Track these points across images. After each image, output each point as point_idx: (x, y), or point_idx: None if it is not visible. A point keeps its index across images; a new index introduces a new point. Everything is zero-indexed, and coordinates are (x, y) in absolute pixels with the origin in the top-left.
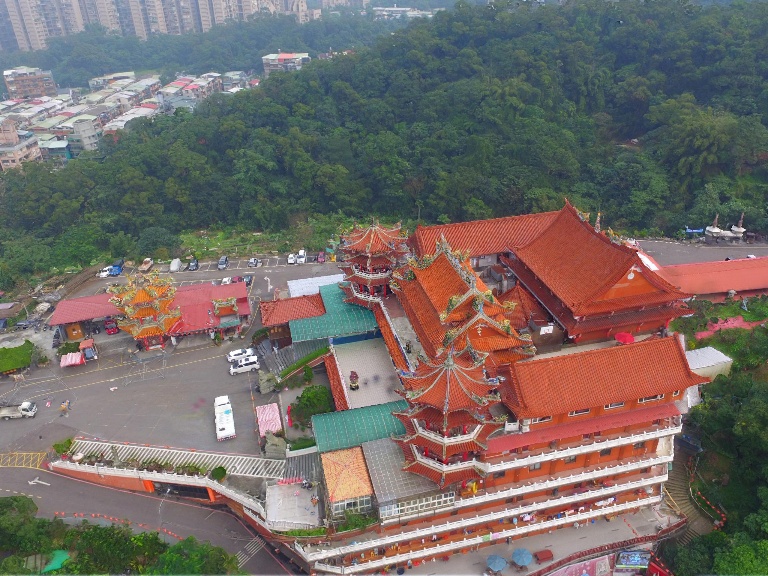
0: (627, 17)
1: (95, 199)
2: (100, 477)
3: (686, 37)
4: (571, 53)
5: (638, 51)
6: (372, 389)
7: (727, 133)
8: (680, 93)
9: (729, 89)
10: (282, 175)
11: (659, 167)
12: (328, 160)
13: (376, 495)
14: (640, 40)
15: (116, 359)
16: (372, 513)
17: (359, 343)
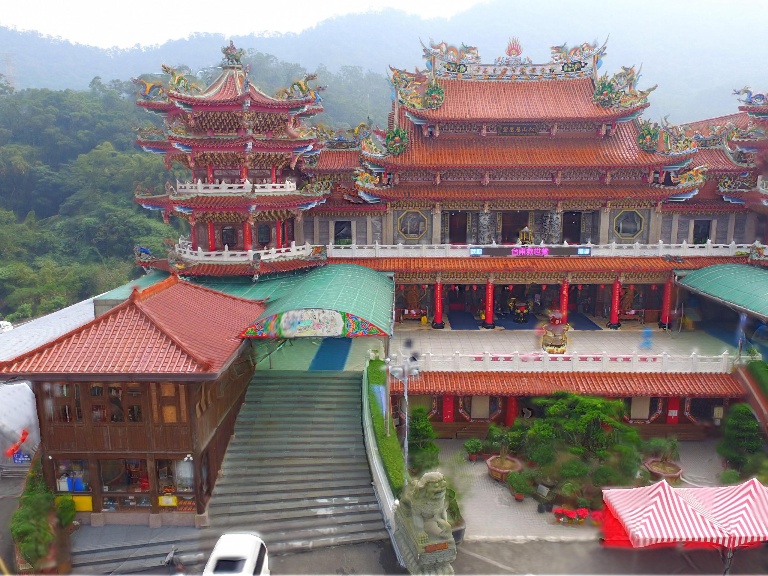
0: None
1: None
2: None
3: (40, 103)
4: None
5: None
6: None
7: None
8: (56, 167)
9: (124, 150)
10: None
11: (136, 214)
12: None
13: None
14: None
15: None
16: None
17: (360, 347)
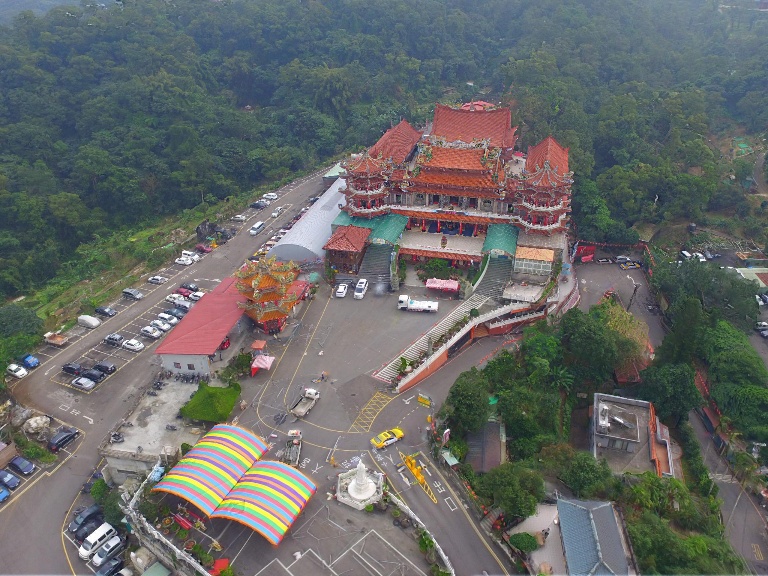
0: (191, 12)
1: None
2: None
3: (253, 22)
4: (184, 45)
5: (213, 38)
6: (451, 244)
7: (346, 76)
8: (263, 64)
9: (303, 53)
10: None
11: (315, 111)
12: (38, 194)
13: (559, 248)
14: (212, 29)
15: (274, 349)
16: (558, 261)
17: None
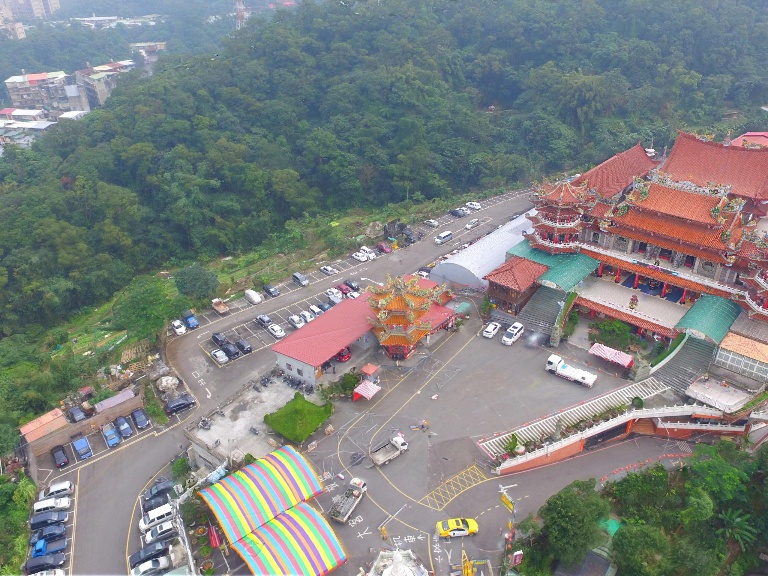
0: (456, 6)
1: (28, 265)
2: (546, 457)
3: (516, 19)
4: (438, 38)
5: (472, 34)
6: (644, 306)
7: (601, 85)
8: (517, 64)
9: (562, 56)
10: (218, 193)
11: (556, 120)
12: (267, 167)
13: None
14: (473, 24)
15: (390, 377)
16: None
17: None
